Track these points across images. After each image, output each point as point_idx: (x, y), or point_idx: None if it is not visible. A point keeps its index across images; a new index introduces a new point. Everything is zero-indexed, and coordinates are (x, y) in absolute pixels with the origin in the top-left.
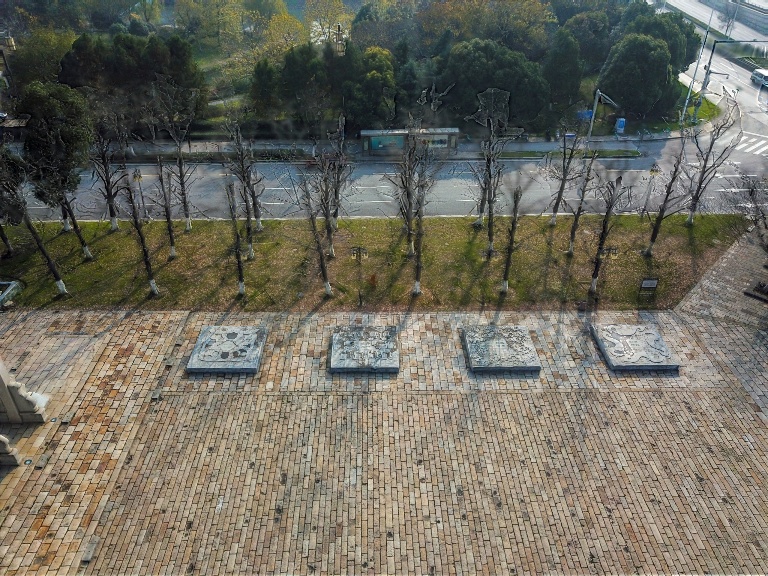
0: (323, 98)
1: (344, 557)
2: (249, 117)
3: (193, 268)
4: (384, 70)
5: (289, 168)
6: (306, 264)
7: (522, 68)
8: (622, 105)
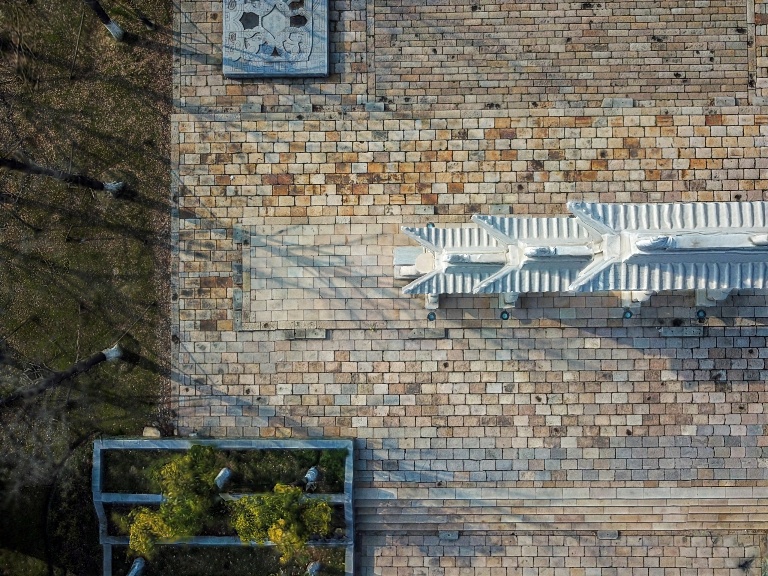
0: None
1: None
2: None
3: (34, 144)
4: None
5: None
6: None
7: None
8: None
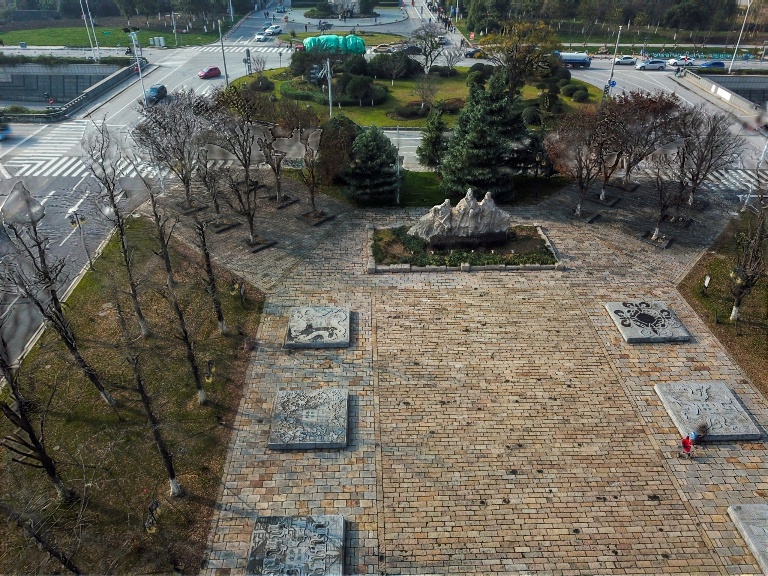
0: None
1: (614, 571)
2: None
3: None
4: None
5: None
6: None
7: None
8: None
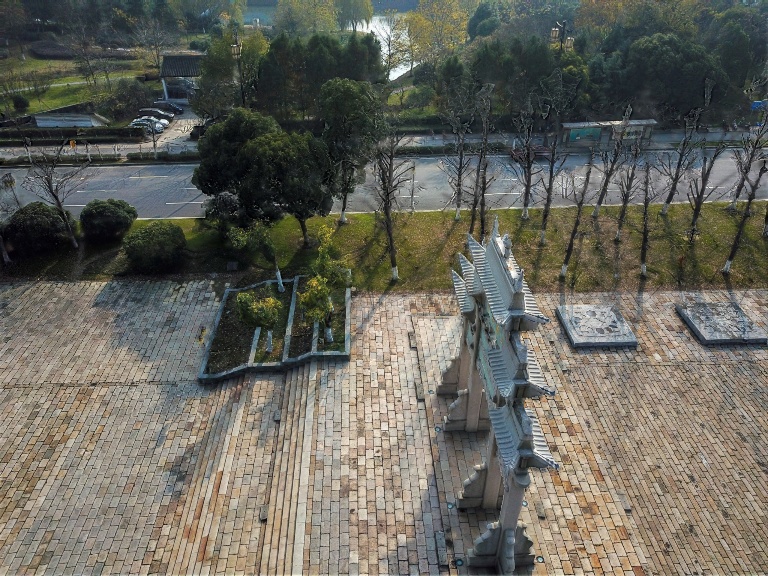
0: (530, 93)
1: None
2: (428, 113)
3: None
4: (577, 65)
5: (500, 160)
6: (600, 248)
7: (708, 61)
8: None
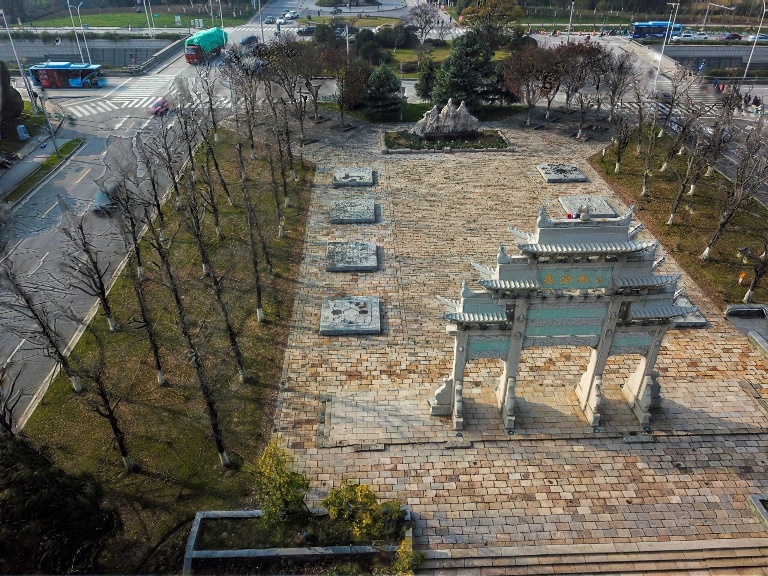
0: None
1: None
2: None
3: None
4: None
5: None
6: None
7: None
8: (6, 115)
